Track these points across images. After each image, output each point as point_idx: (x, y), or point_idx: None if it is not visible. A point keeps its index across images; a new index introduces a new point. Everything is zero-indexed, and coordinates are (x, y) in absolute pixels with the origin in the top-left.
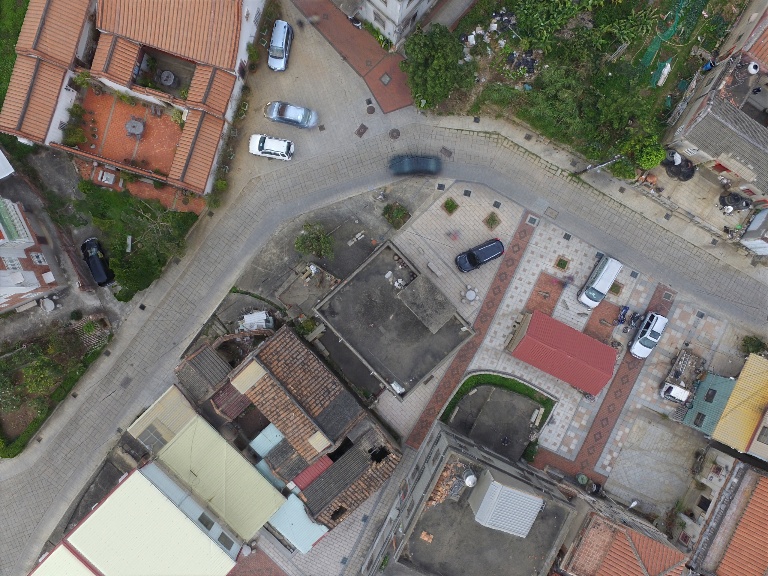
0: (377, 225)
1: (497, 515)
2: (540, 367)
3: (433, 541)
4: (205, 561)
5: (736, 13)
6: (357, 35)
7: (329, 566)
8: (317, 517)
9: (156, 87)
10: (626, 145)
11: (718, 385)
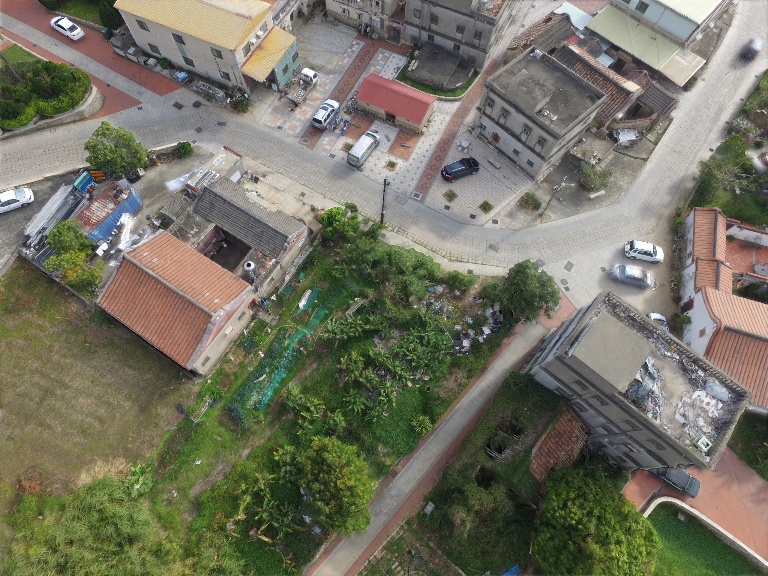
0: (544, 196)
1: None
2: (415, 90)
3: None
4: None
5: (230, 355)
6: None
7: (543, 4)
8: None
9: (758, 292)
10: None
11: None
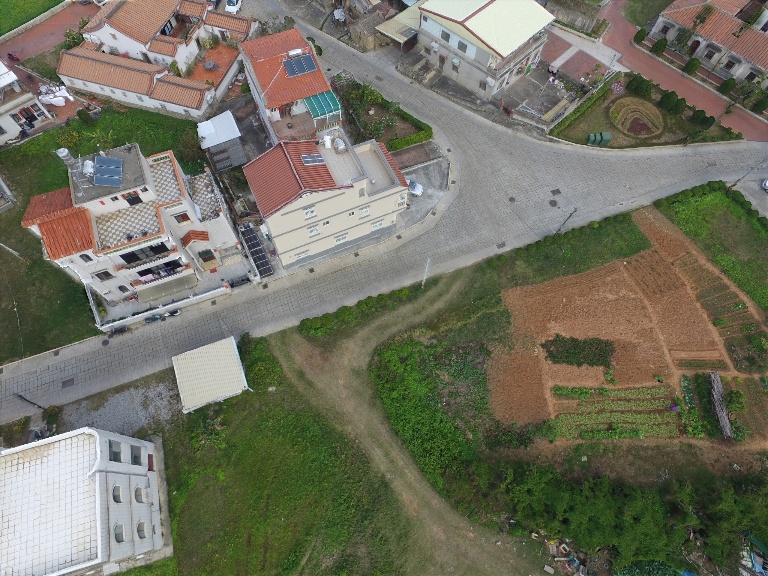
0: None
1: None
2: None
3: None
4: None
5: None
6: None
7: None
8: None
9: None
10: None
11: None
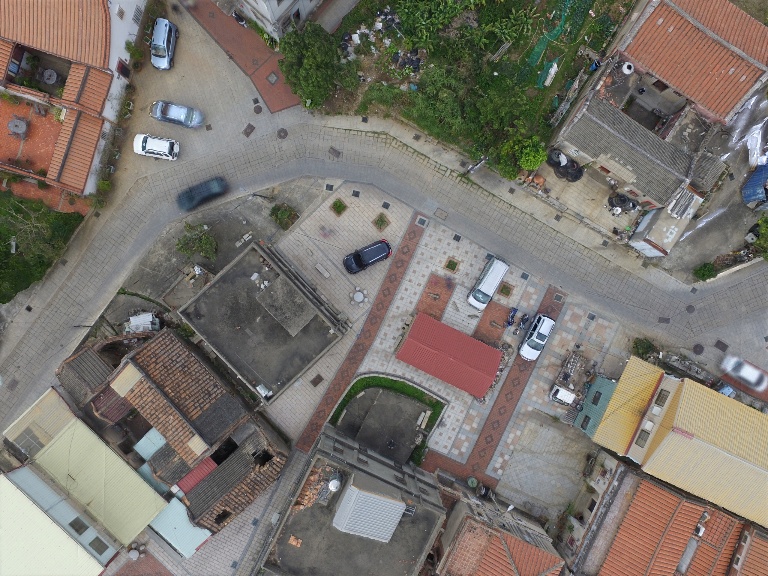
0: (265, 226)
1: (354, 520)
2: (424, 369)
3: (302, 546)
4: (71, 566)
5: (623, 12)
6: (243, 33)
7: (219, 570)
8: (199, 521)
9: (35, 86)
10: (505, 146)
11: (603, 388)
